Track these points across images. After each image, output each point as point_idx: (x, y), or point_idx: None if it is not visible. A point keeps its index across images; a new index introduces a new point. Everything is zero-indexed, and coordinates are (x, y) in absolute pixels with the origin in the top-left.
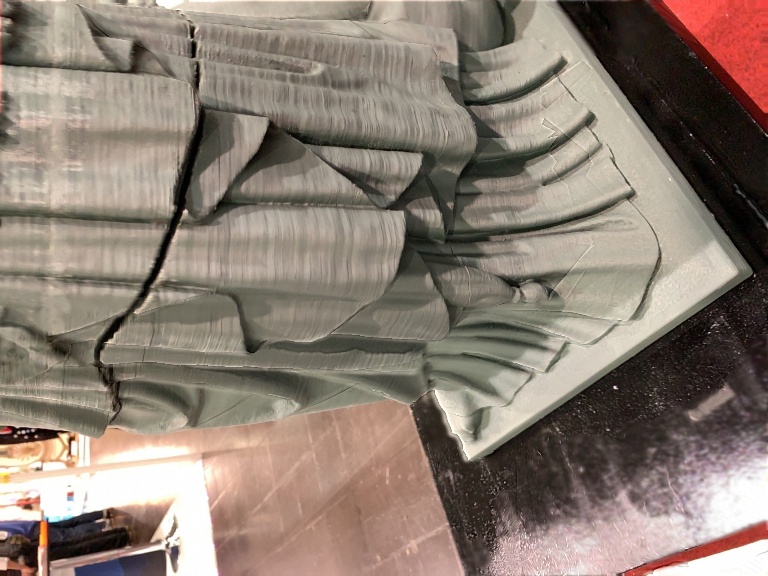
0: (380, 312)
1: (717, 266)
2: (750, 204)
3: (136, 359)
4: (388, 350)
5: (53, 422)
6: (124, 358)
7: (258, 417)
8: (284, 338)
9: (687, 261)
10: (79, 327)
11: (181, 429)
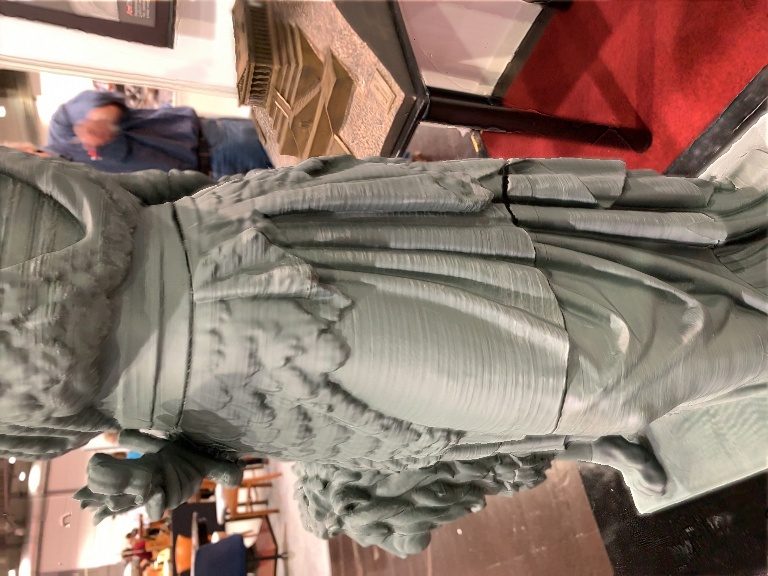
0: (640, 179)
1: (767, 118)
2: (745, 119)
3: (533, 215)
4: (683, 211)
5: (521, 320)
6: (526, 213)
7: (686, 335)
8: (603, 191)
9: (760, 135)
10: (488, 172)
11: (632, 347)
